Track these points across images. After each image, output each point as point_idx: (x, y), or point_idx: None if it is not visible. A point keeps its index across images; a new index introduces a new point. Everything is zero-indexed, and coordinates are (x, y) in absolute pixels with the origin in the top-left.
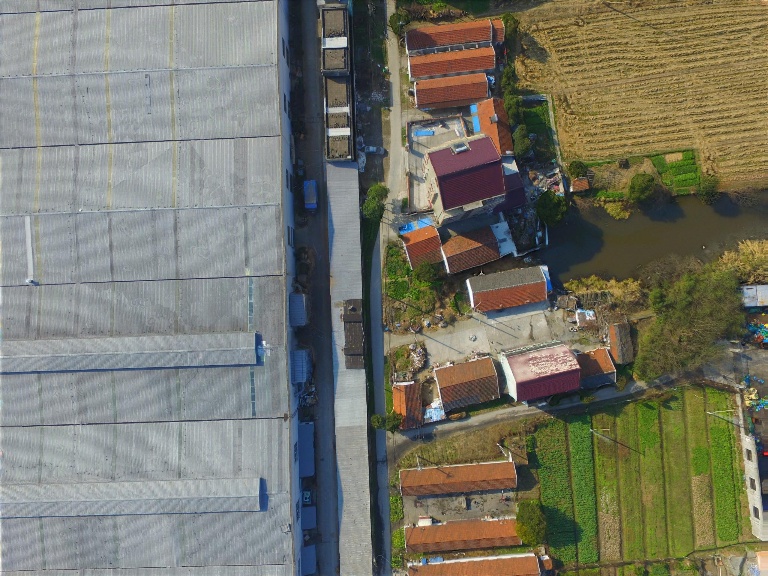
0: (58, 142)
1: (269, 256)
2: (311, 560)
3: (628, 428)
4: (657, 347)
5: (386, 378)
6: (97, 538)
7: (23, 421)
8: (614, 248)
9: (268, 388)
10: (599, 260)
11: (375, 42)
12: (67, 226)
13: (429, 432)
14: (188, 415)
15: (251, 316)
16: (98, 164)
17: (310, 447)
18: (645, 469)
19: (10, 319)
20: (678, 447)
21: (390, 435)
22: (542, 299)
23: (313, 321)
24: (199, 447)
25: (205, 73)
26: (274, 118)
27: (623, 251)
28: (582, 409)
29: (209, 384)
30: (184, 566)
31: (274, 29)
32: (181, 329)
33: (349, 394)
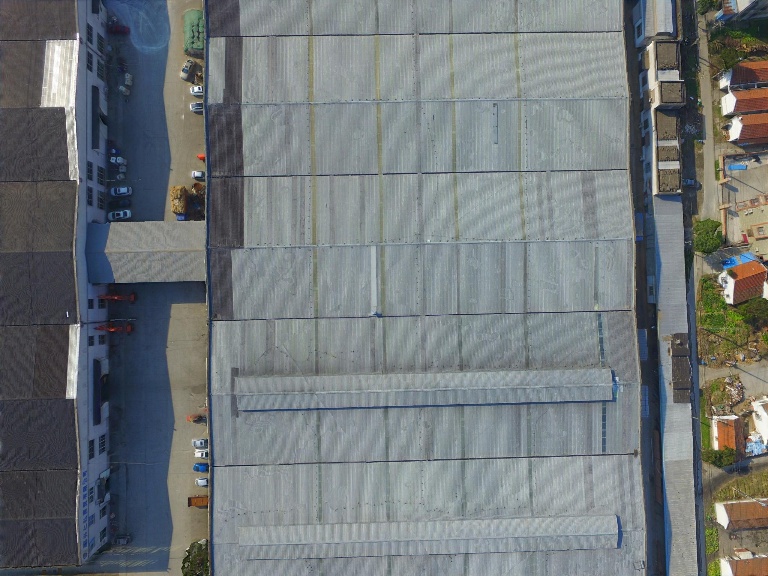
0: (400, 170)
1: (618, 291)
2: None
3: None
4: None
5: (702, 411)
6: None
7: (367, 457)
8: None
9: (619, 424)
10: None
11: (688, 74)
12: (414, 257)
13: (745, 465)
14: (538, 451)
15: (603, 351)
16: (443, 194)
17: None
18: None
19: (354, 352)
20: None
21: (706, 468)
22: None
23: None
24: (550, 484)
25: (554, 104)
26: (622, 151)
27: None
28: None
29: (560, 420)
30: None
31: (621, 61)
32: (532, 364)
33: (677, 428)
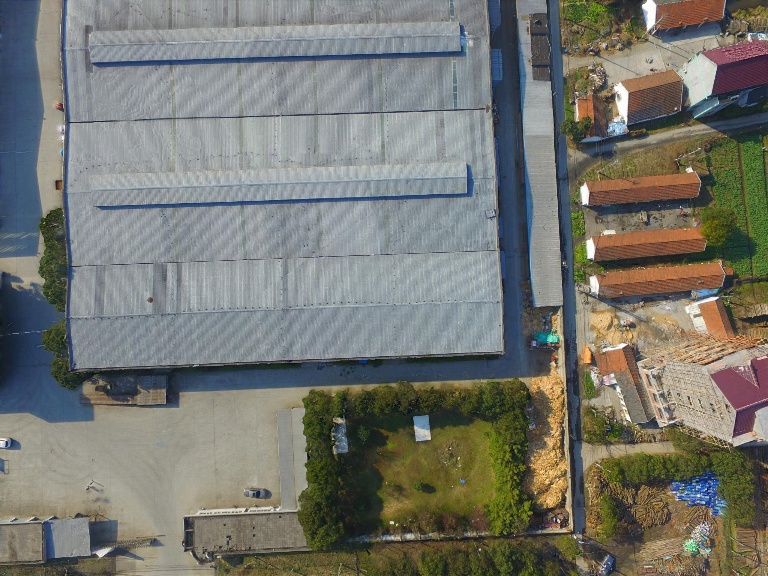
0: None
1: None
2: (502, 265)
3: None
4: None
5: (566, 98)
6: (300, 226)
7: (221, 112)
8: None
9: (470, 79)
10: None
11: None
12: None
13: (609, 149)
14: (390, 106)
15: (452, 8)
16: None
17: (497, 159)
18: None
19: (207, 10)
20: None
21: (571, 153)
22: (719, 18)
23: (493, 43)
24: (402, 136)
25: None
26: None
27: None
28: (755, 127)
29: (411, 75)
30: (388, 254)
31: None
32: (383, 20)
33: (536, 104)
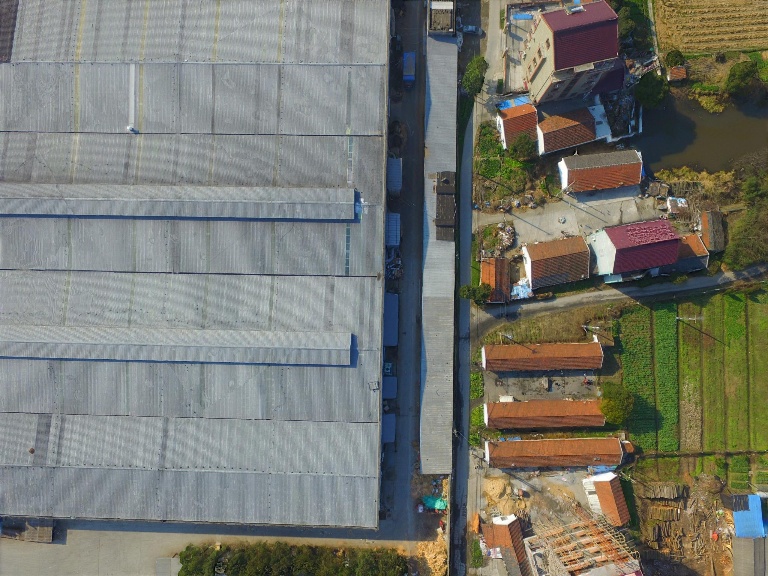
0: None
1: (371, 116)
2: (391, 428)
3: (714, 319)
4: (750, 234)
5: (473, 255)
6: (183, 386)
7: (115, 266)
8: (707, 141)
9: (363, 246)
10: (691, 152)
11: None
12: (171, 76)
13: (514, 311)
14: (281, 269)
15: (350, 174)
16: (205, 18)
17: (395, 317)
18: (729, 361)
19: (109, 165)
20: (764, 340)
21: (474, 312)
22: (635, 182)
23: (402, 195)
24: (291, 301)
25: None
26: None
27: (716, 144)
28: (669, 296)
29: (304, 239)
30: (269, 419)
31: None
32: (279, 183)
33: (438, 265)
